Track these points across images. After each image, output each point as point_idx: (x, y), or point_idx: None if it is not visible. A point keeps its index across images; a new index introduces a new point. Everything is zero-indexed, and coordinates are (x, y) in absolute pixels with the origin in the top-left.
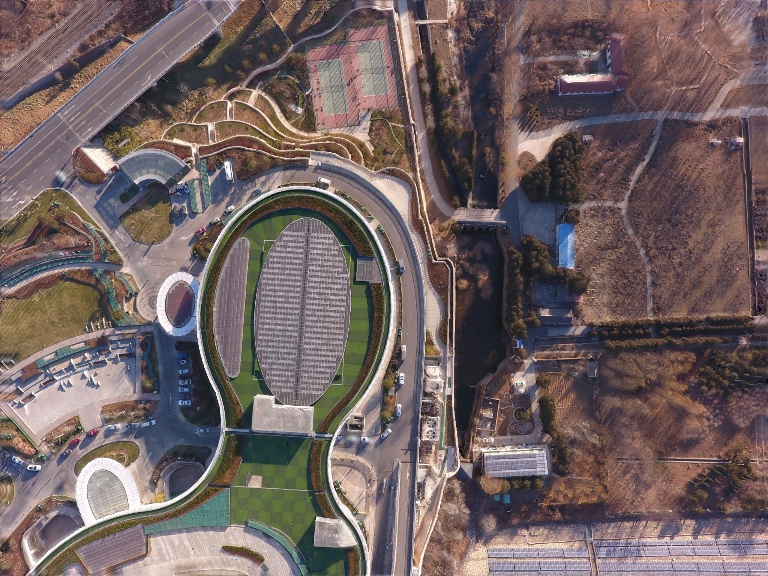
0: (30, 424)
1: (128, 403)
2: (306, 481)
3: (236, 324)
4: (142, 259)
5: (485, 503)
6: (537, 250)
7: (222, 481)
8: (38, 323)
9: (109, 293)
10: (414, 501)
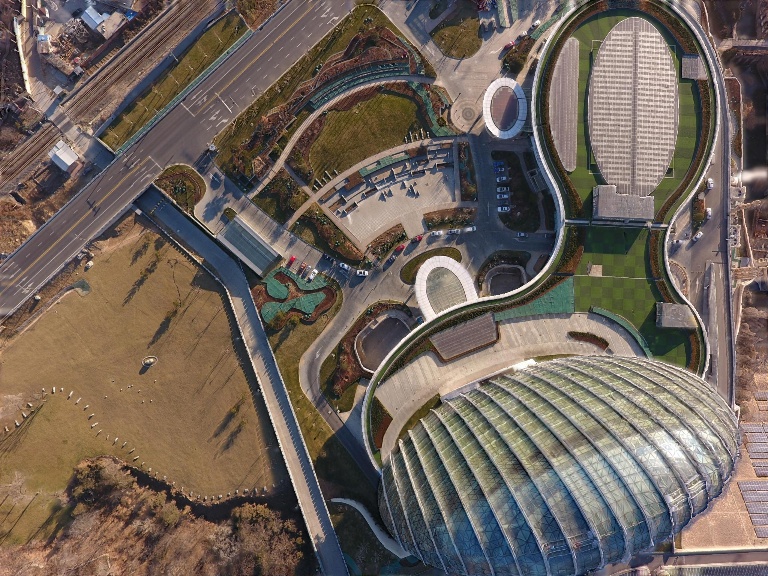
0: (354, 232)
1: (449, 210)
2: (644, 269)
3: (571, 120)
4: (453, 73)
5: (763, 320)
6: None
7: (566, 269)
8: (360, 133)
9: (427, 104)
10: (730, 298)
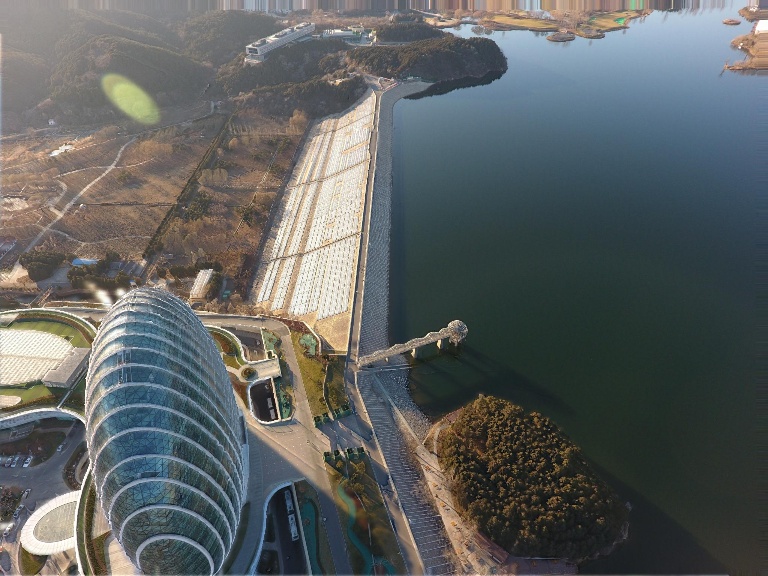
0: None
1: None
2: None
3: None
4: None
5: None
6: (75, 268)
7: None
8: None
9: None
10: None
